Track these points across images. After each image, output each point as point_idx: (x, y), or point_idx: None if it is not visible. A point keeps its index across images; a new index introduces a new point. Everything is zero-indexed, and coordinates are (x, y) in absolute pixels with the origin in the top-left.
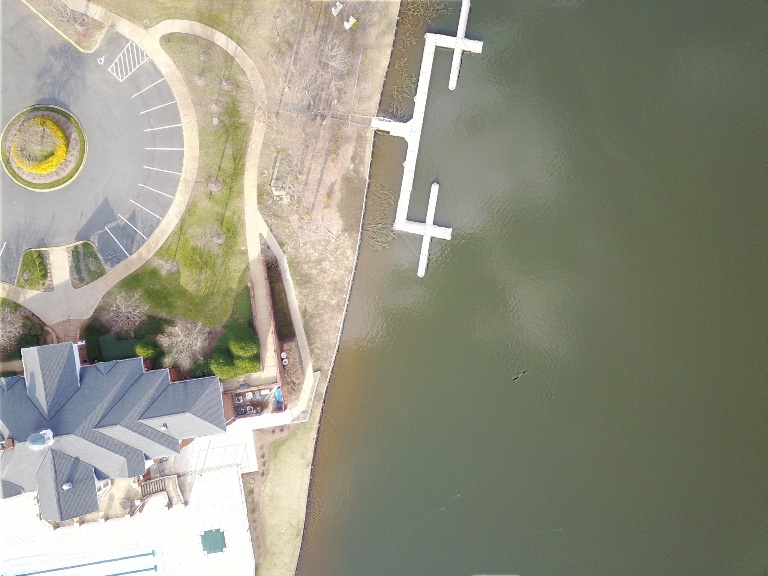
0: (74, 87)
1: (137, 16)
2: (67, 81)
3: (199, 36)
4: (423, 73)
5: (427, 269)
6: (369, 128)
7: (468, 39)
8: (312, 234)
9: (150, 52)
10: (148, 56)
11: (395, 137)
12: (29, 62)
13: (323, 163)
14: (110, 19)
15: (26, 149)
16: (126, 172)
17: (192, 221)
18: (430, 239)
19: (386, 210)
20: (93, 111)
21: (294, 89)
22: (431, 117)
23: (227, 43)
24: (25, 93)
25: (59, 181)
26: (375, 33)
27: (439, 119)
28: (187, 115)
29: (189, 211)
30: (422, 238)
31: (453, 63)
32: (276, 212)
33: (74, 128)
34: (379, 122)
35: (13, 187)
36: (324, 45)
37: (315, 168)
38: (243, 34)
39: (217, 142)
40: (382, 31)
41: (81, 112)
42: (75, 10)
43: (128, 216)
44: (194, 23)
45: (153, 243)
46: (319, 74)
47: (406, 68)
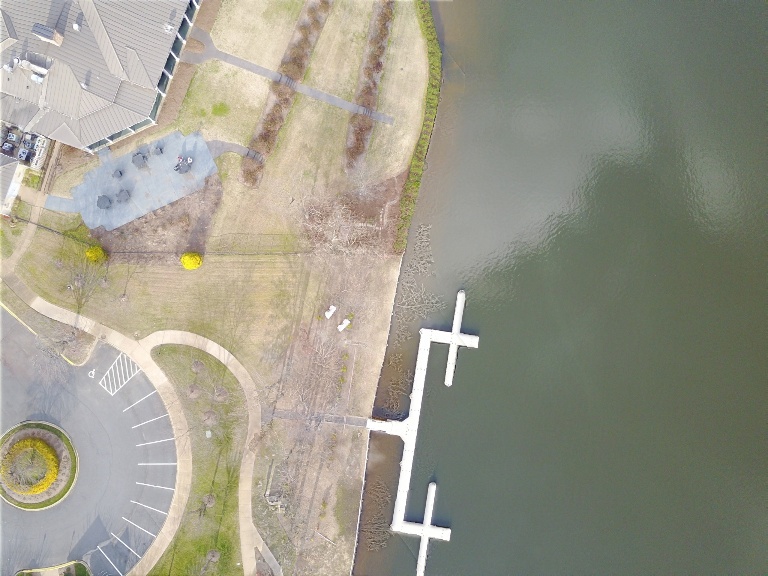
0: (64, 402)
1: (128, 328)
2: (57, 396)
3: (191, 346)
4: (418, 370)
5: (425, 571)
6: (364, 429)
7: (463, 334)
8: (308, 542)
9: (141, 364)
10: (139, 368)
11: (391, 435)
12: (18, 377)
13: (318, 468)
14: (100, 331)
15: (16, 470)
16: (118, 489)
17: (186, 539)
18: (428, 540)
19: (383, 509)
20: (84, 426)
21: (288, 395)
22: (427, 412)
23: (219, 352)
24: (15, 409)
25: (50, 500)
26: (369, 331)
27: (435, 413)
28: (180, 429)
29: (183, 528)
30: (420, 539)
31: (449, 360)
32: (271, 523)
33: (65, 445)
34: (375, 423)
35: (3, 507)
36: (318, 348)
37: (310, 474)
38: (235, 342)
39: (210, 456)
40: (376, 328)
41: (72, 428)
42: (65, 323)
43: (121, 534)
44: (186, 333)
45: (147, 562)
46: (313, 378)
47: (401, 364)
